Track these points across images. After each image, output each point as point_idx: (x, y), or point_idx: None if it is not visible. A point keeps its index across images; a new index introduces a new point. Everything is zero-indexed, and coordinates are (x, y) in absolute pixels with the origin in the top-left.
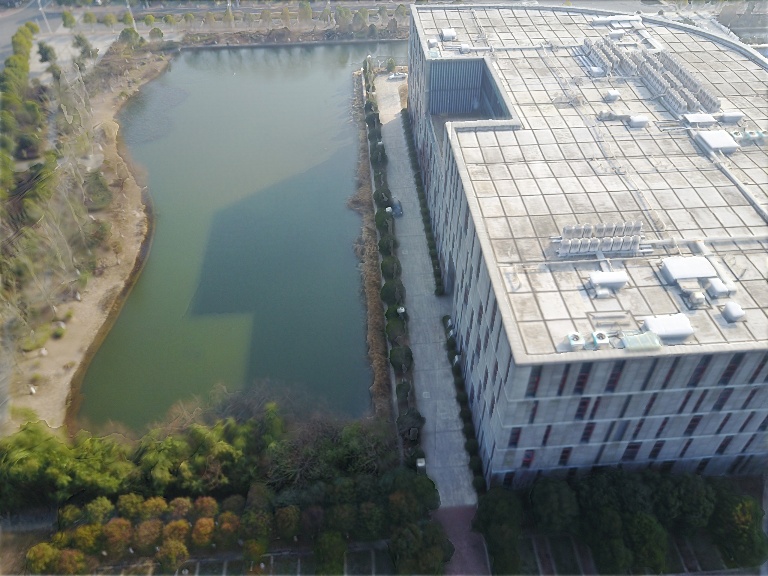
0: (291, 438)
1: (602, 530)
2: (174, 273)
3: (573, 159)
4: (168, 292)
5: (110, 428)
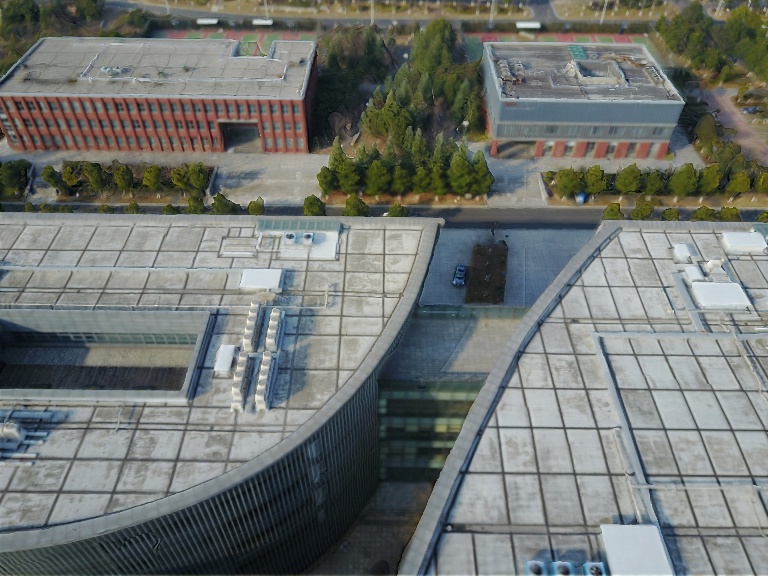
0: None
1: None
2: None
3: None
4: None
5: None
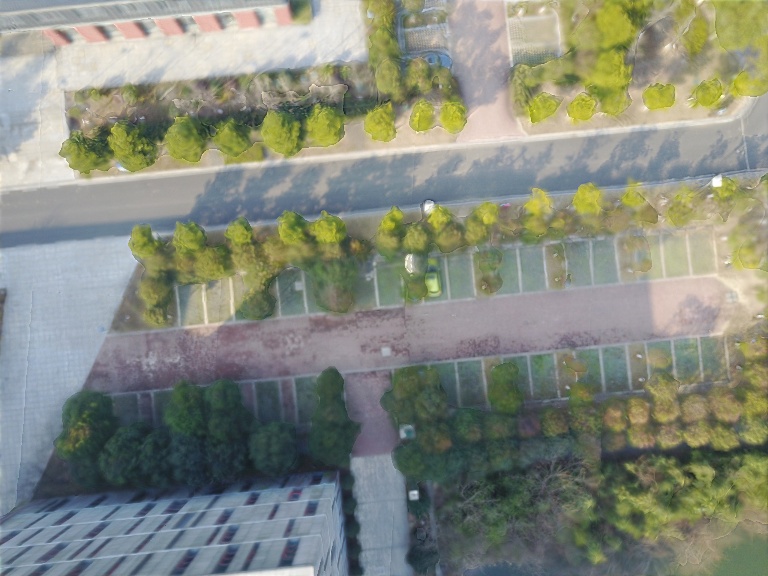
0: (567, 515)
1: (230, 417)
2: None
3: None
4: None
5: None
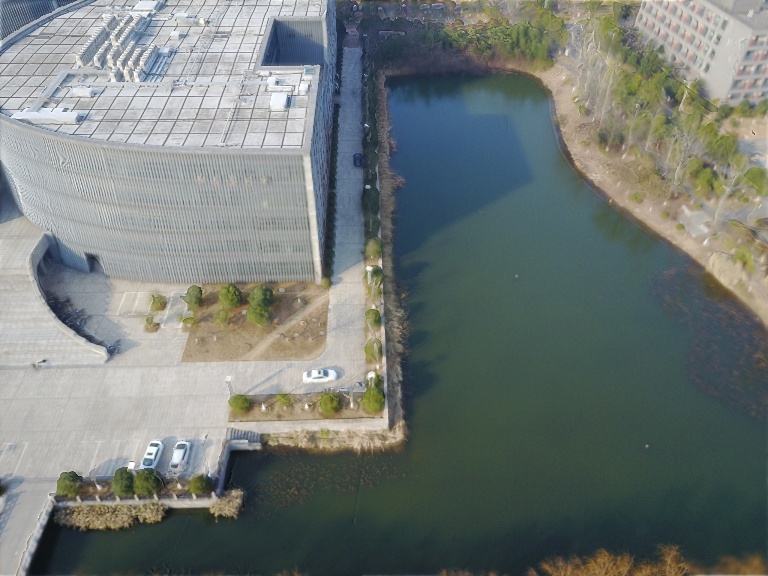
0: (419, 28)
1: None
2: (533, 144)
3: (251, 6)
4: (528, 132)
5: (518, 83)
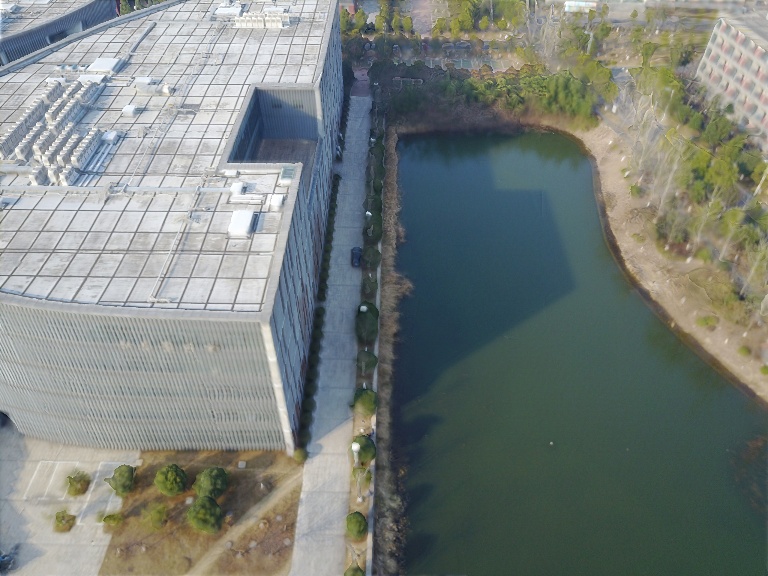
0: (440, 78)
1: None
2: (573, 232)
3: None
4: (567, 215)
5: (555, 145)
